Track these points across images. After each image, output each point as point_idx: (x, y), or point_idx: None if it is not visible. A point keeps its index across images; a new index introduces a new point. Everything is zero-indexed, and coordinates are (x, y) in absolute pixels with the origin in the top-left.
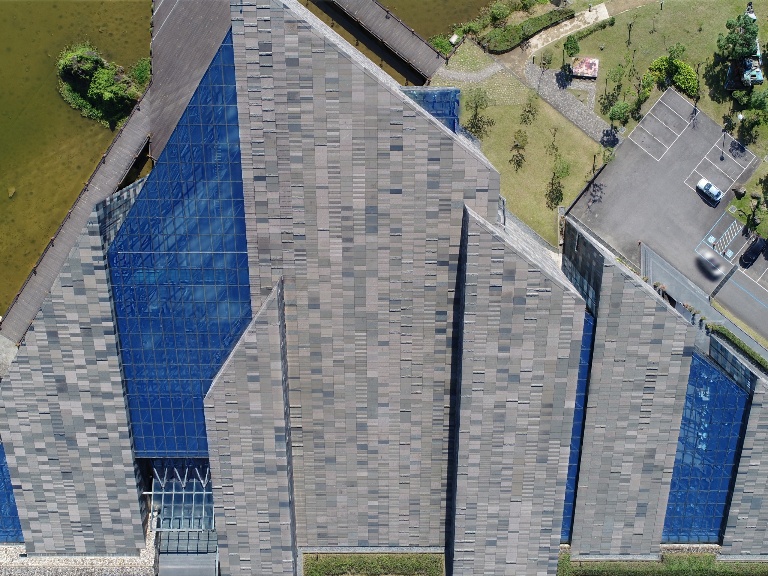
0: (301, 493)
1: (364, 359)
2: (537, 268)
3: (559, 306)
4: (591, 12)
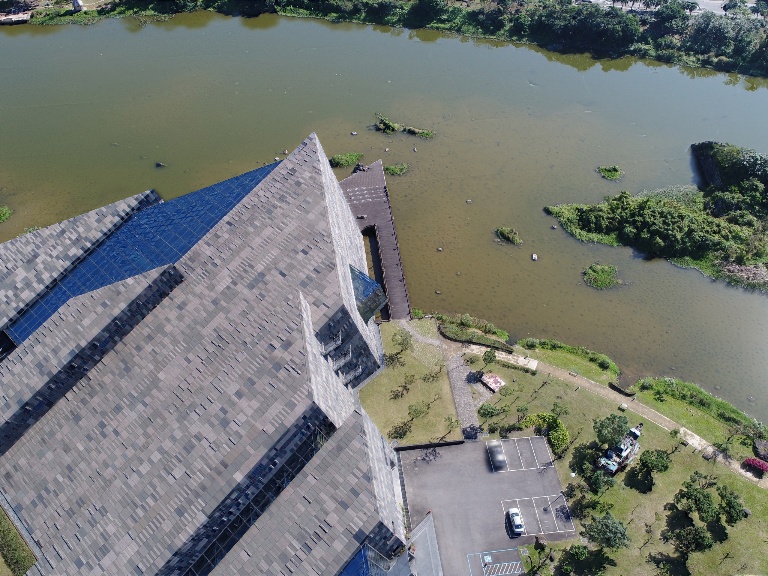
0: (37, 429)
1: (168, 362)
2: (306, 352)
3: (296, 390)
4: (525, 359)
